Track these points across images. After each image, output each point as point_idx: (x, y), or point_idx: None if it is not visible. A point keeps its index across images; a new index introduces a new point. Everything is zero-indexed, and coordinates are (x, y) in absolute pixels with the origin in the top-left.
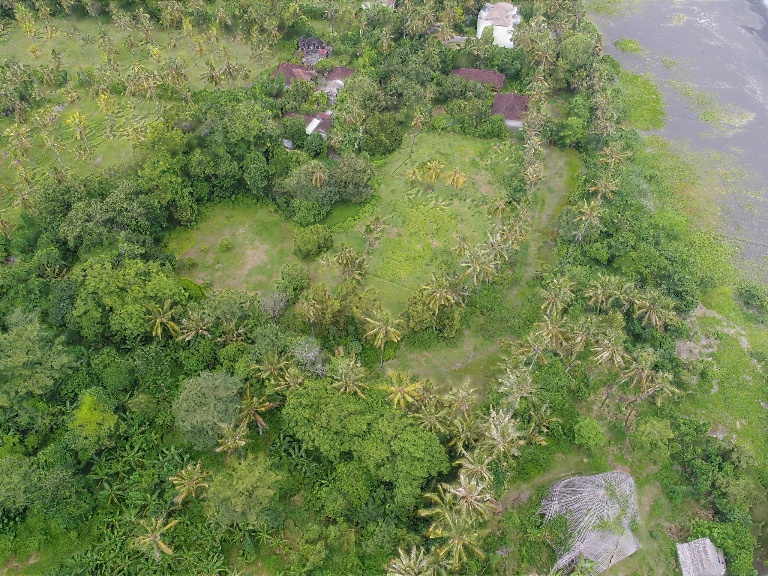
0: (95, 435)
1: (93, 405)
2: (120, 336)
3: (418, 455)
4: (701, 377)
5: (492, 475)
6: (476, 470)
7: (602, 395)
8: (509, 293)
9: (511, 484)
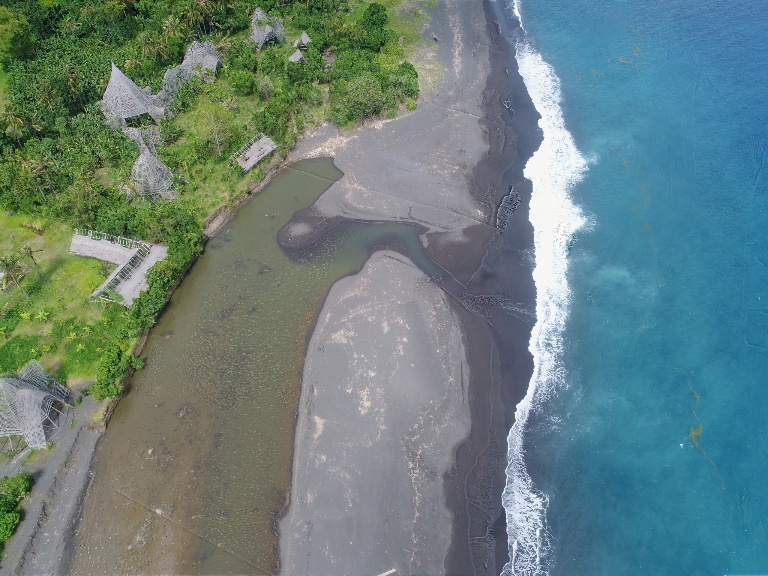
0: (49, 6)
1: None
2: None
3: None
4: (343, 12)
5: None
6: None
7: None
8: None
9: (238, 35)
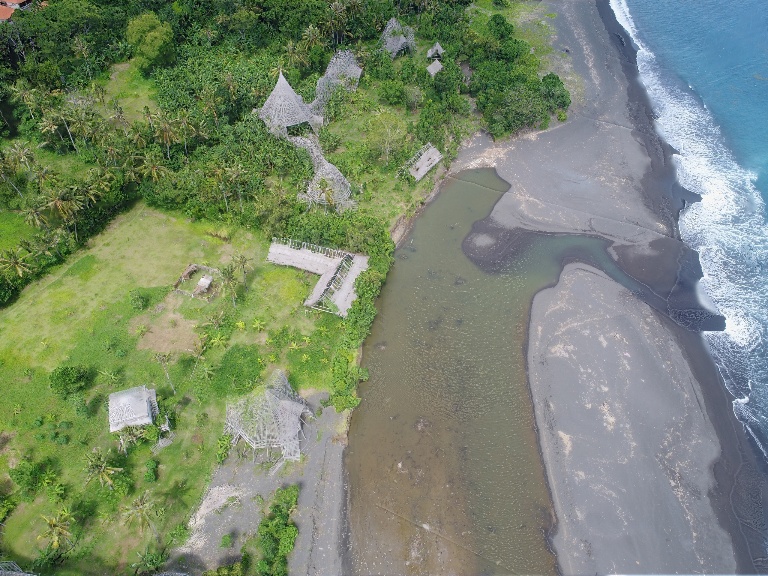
0: (180, 13)
1: (178, 6)
2: (185, 2)
3: (318, 5)
4: None
5: (350, 20)
6: (341, 8)
7: (414, 26)
8: (380, 2)
9: (364, 45)
